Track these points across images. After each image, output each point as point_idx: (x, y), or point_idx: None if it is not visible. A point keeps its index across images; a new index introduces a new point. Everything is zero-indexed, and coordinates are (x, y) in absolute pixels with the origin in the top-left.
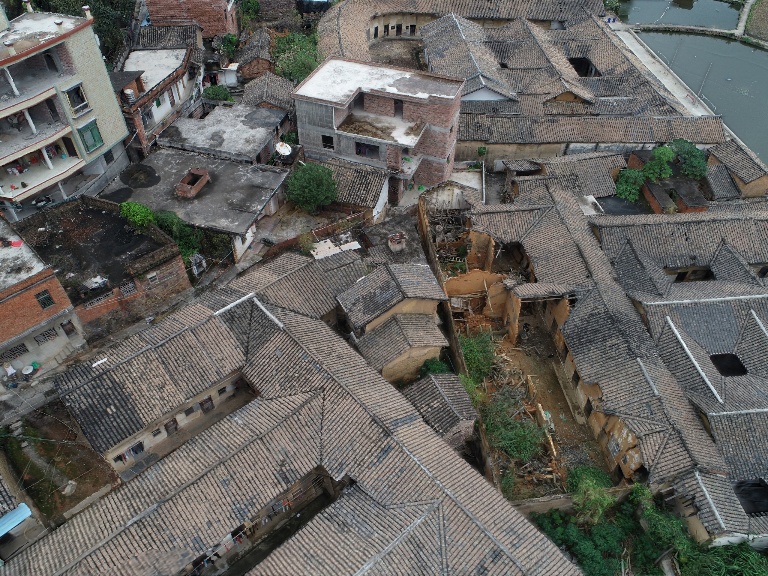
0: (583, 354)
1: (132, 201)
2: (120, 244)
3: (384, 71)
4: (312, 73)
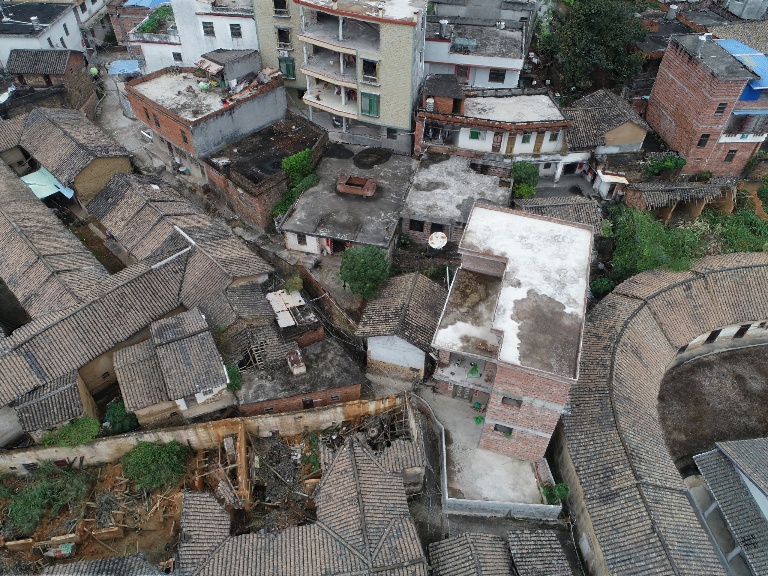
0: (84, 570)
1: (333, 160)
2: (271, 165)
3: (575, 284)
4: (534, 215)
